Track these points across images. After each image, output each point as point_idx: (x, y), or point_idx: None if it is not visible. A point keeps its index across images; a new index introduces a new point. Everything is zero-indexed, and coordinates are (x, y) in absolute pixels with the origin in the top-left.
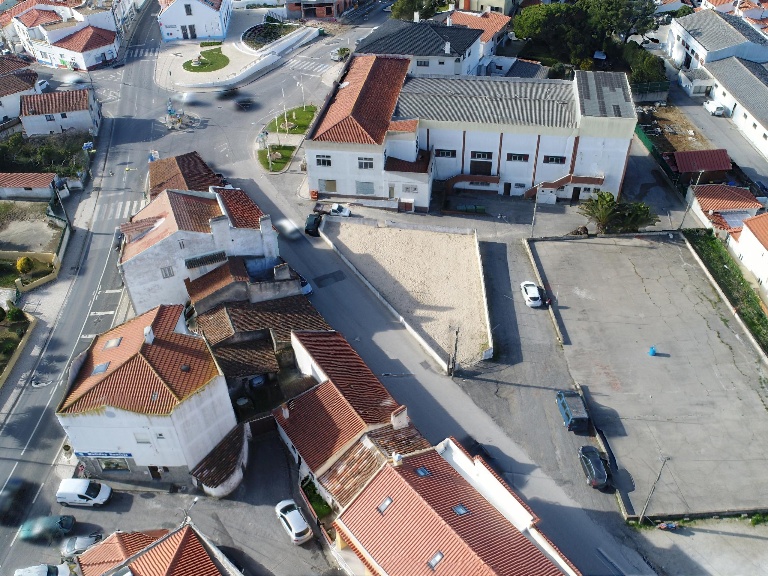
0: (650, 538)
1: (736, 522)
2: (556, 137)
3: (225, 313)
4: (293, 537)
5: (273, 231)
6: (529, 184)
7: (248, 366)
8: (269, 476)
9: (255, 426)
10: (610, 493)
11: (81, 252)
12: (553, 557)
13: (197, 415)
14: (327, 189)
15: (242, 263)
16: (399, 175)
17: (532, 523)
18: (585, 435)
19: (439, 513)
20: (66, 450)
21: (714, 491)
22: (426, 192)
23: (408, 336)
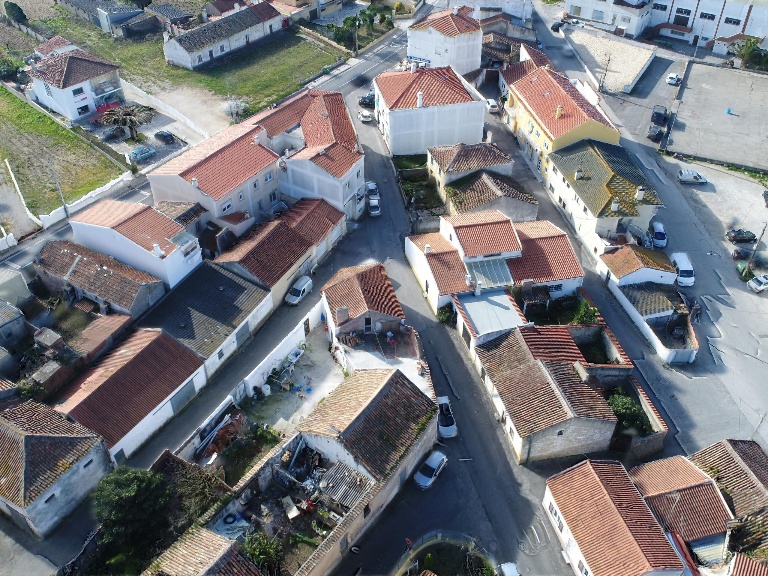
0: (666, 159)
1: (719, 166)
2: (737, 4)
3: (492, 35)
4: (489, 108)
5: (531, 4)
6: (711, 38)
7: (494, 55)
8: (487, 94)
9: (488, 74)
10: (657, 143)
11: (426, 11)
12: (601, 113)
13: (465, 47)
14: (575, 13)
15: (509, 16)
16: (621, 8)
17: (598, 100)
18: (660, 126)
19: (556, 81)
20: (401, 63)
21: (716, 156)
22: (635, 23)
23: (586, 75)
